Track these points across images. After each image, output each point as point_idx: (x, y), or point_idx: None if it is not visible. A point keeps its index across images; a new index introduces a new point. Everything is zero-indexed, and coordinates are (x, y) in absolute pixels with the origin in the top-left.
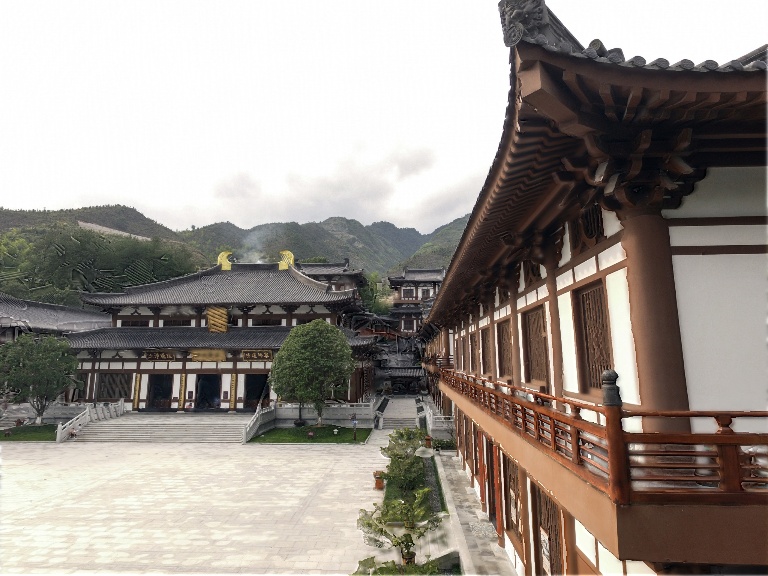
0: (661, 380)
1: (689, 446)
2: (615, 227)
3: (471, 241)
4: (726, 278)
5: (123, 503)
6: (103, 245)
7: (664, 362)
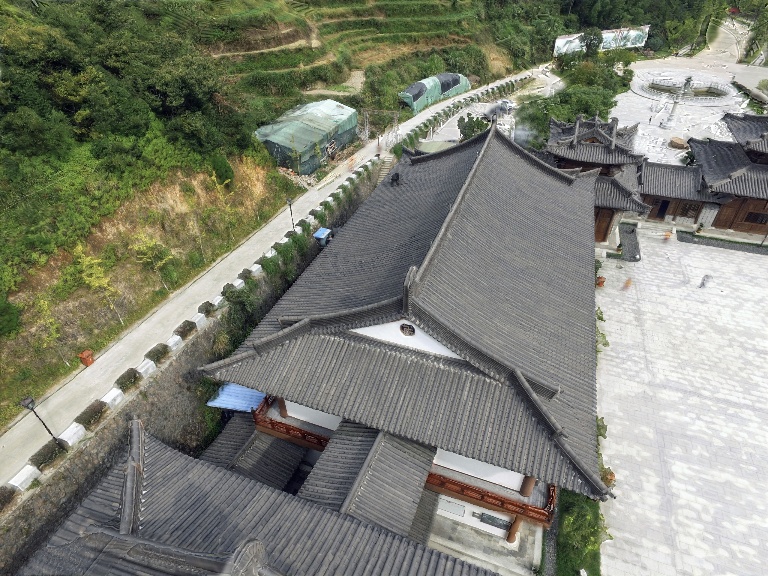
0: None
1: None
2: None
3: None
4: None
5: None
6: None
7: None
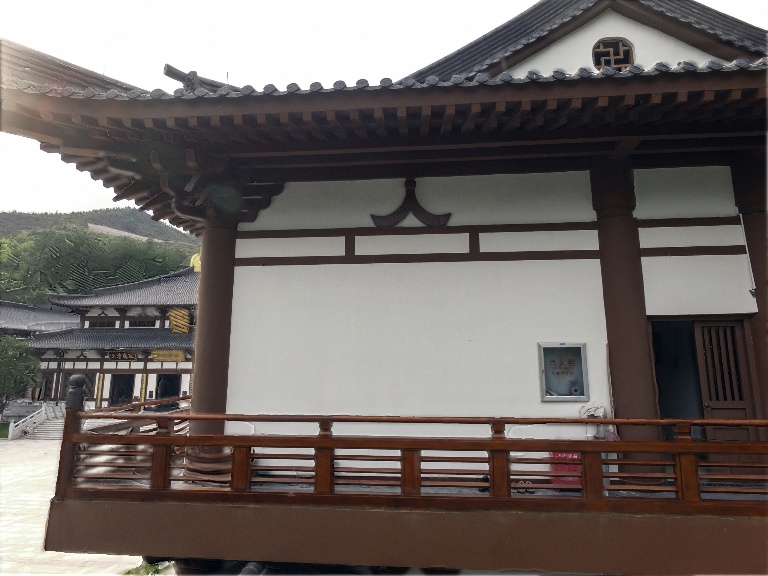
0: (196, 385)
1: (128, 446)
2: None
3: None
4: (279, 288)
5: (25, 498)
6: (97, 247)
7: (201, 368)
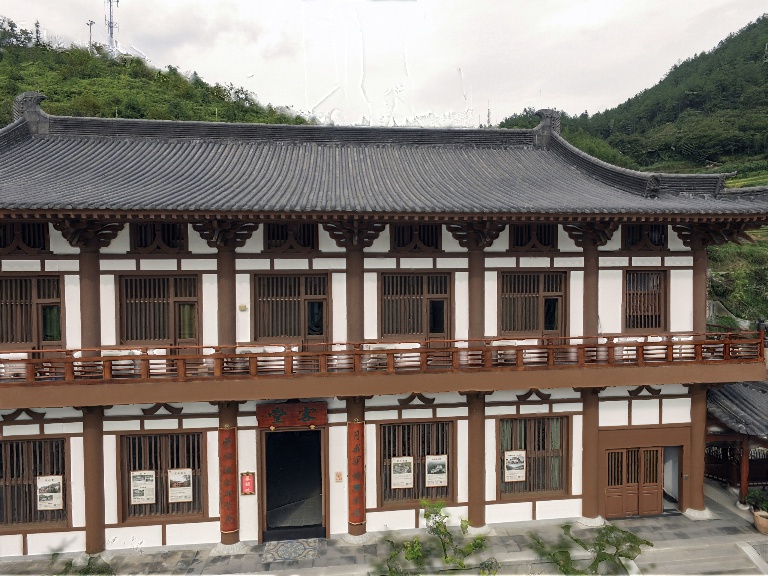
0: None
1: None
2: (679, 247)
3: (625, 220)
4: None
5: None
6: None
7: None
